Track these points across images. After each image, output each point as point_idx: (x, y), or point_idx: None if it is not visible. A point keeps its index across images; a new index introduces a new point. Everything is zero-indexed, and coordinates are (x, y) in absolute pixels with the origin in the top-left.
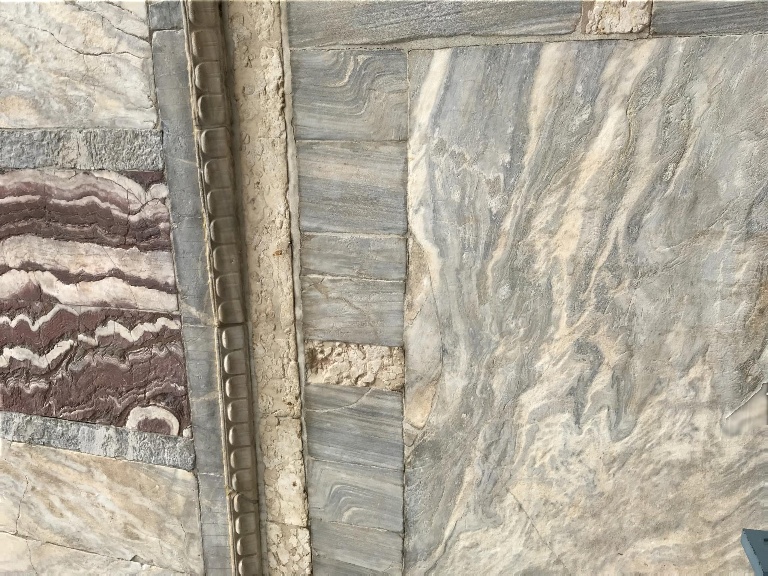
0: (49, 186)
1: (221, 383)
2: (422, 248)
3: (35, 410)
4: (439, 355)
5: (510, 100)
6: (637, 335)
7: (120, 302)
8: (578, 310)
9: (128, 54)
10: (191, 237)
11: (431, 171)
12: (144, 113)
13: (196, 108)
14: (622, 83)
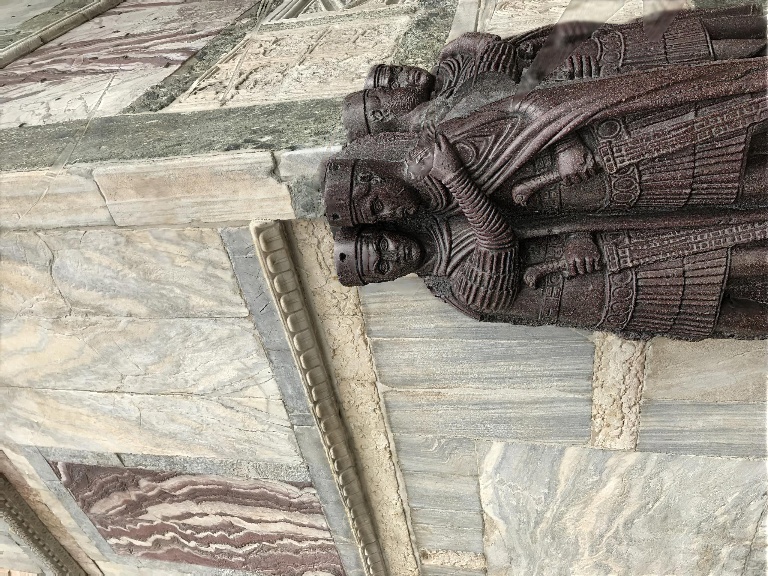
0: (229, 483)
1: (367, 570)
2: (493, 519)
3: (237, 568)
4: (508, 560)
5: (546, 468)
6: (632, 561)
7: (290, 532)
8: (595, 551)
9: (277, 433)
10: (336, 510)
11: (496, 491)
12: (293, 458)
13: (334, 468)
14: (619, 468)
